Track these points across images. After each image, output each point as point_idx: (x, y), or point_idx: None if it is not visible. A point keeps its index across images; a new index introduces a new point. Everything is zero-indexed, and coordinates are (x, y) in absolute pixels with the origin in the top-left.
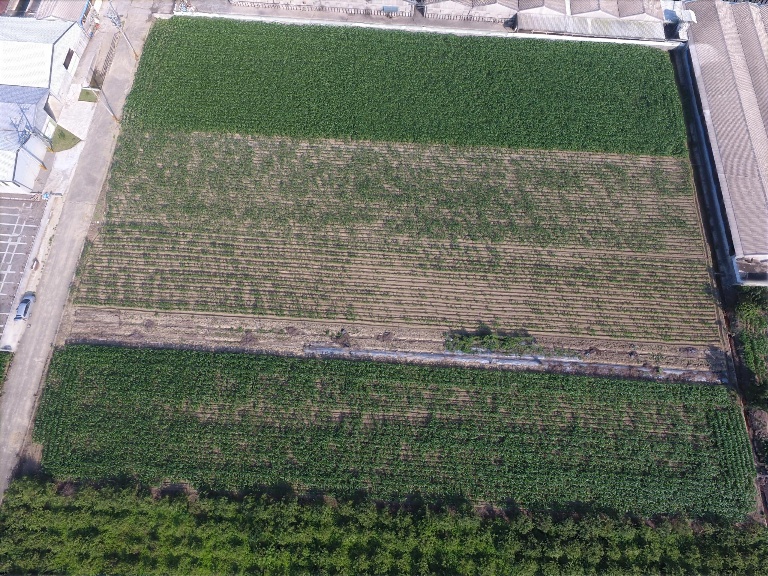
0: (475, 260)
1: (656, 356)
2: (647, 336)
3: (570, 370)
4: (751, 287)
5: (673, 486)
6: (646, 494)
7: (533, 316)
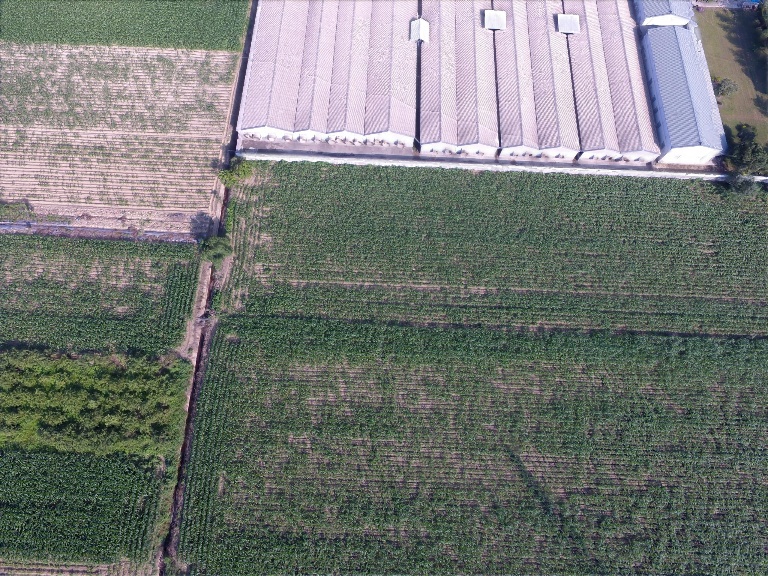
0: (2, 141)
1: (143, 221)
2: (140, 204)
3: (56, 233)
4: (254, 161)
5: (107, 326)
6: (79, 333)
7: (39, 188)
